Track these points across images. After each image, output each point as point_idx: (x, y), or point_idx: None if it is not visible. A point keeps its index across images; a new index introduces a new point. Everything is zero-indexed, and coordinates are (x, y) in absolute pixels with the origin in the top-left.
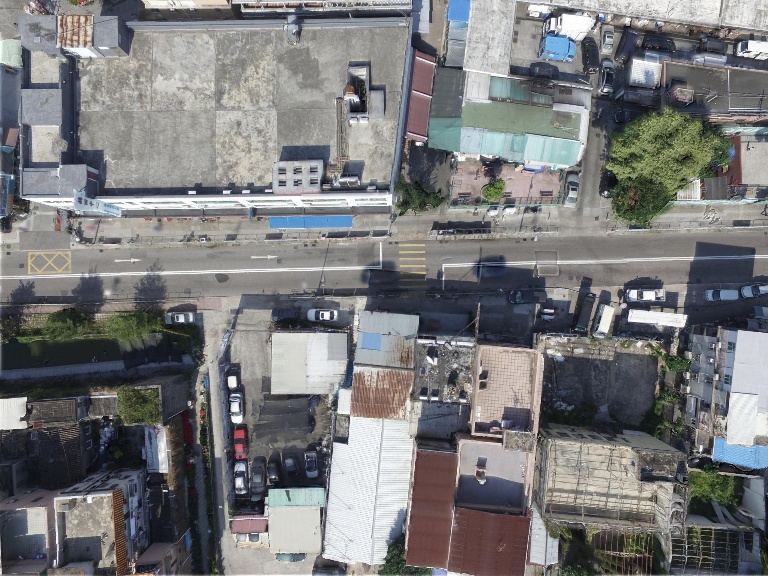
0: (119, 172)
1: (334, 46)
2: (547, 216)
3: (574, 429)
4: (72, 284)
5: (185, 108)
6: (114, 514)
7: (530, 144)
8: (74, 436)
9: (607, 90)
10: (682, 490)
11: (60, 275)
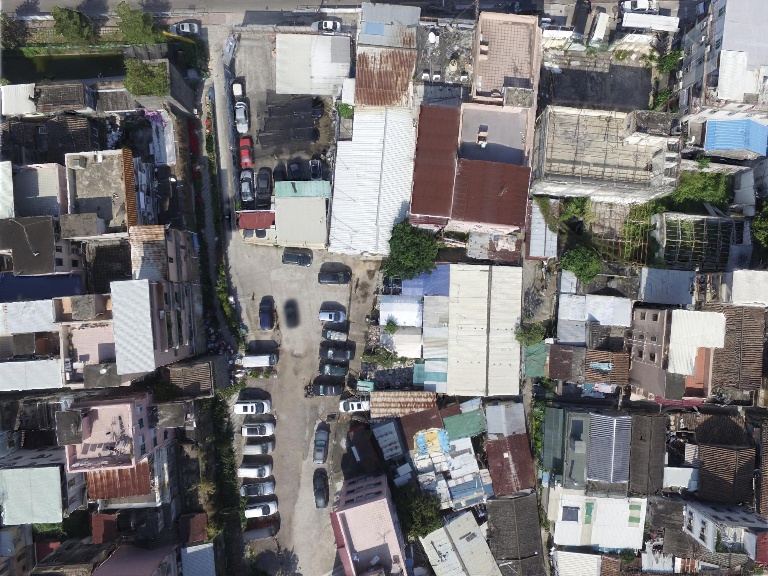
0: None
1: None
2: None
3: None
4: (77, 0)
5: None
6: (124, 170)
7: None
8: (82, 127)
9: None
10: (676, 147)
11: None
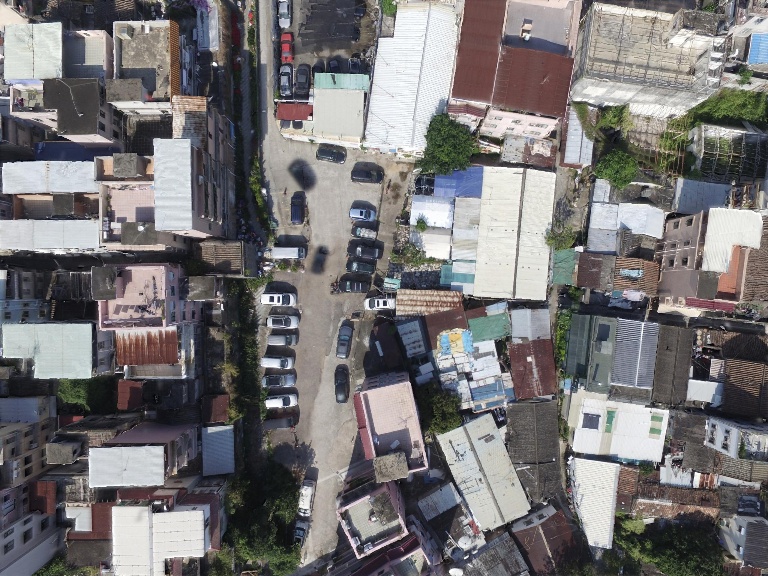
0: None
1: None
2: None
3: None
4: None
5: None
6: (170, 41)
7: None
8: (129, 8)
9: None
10: (721, 48)
11: None
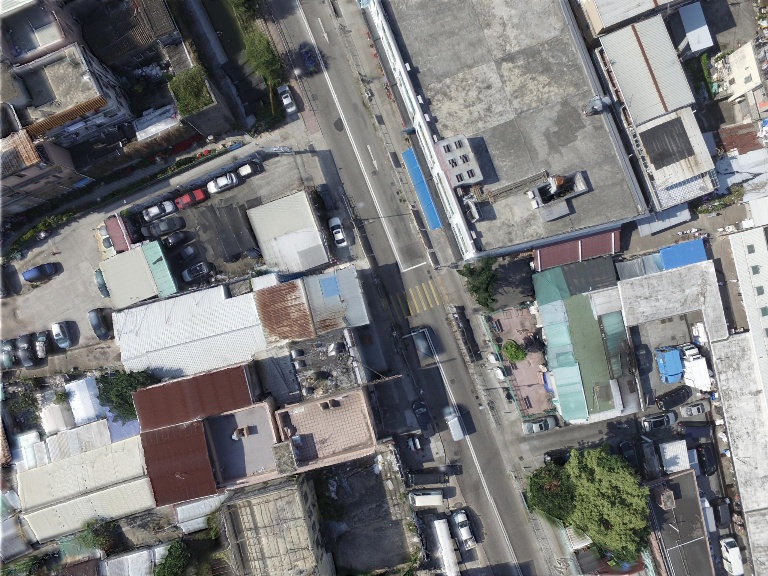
0: None
1: (595, 151)
2: (507, 411)
3: (315, 506)
4: None
5: (486, 31)
6: (82, 104)
7: (569, 370)
8: (141, 40)
9: (647, 425)
10: None
11: None
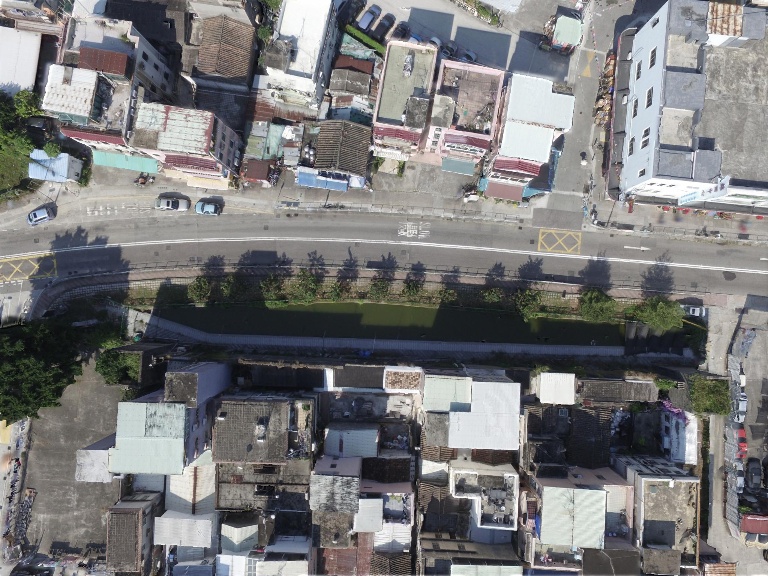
0: (728, 162)
1: None
2: None
3: None
4: (580, 265)
5: None
6: (699, 501)
7: None
8: (608, 417)
9: None
10: None
11: (569, 255)
